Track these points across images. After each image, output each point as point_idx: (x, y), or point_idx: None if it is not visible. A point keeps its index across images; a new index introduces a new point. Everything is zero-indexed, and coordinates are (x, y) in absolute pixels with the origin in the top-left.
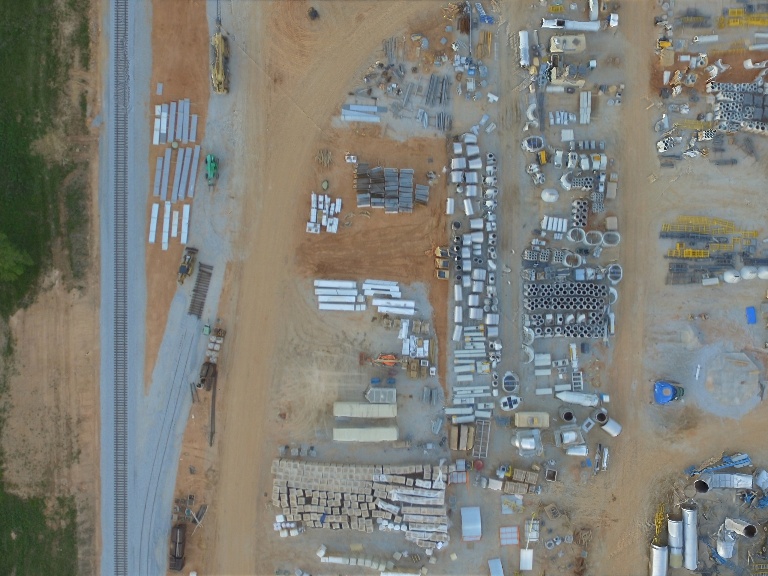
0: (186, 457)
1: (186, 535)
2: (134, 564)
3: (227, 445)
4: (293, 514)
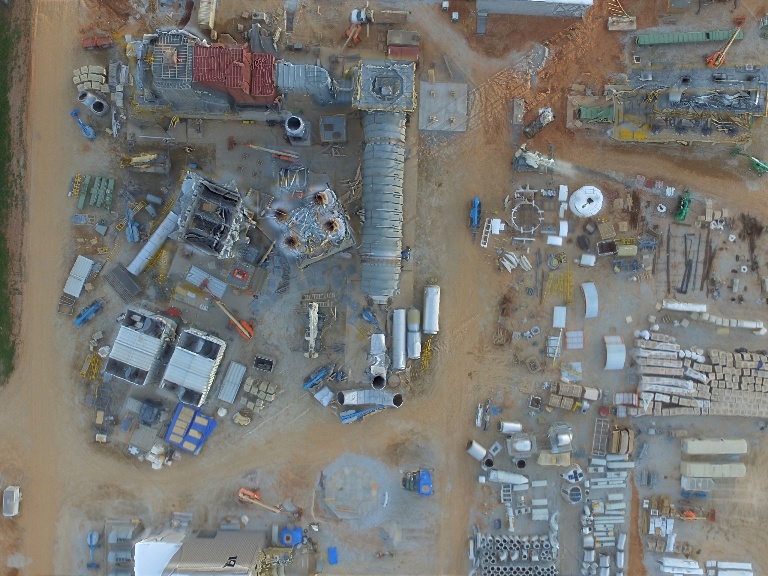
0: None
1: None
2: None
3: None
4: None
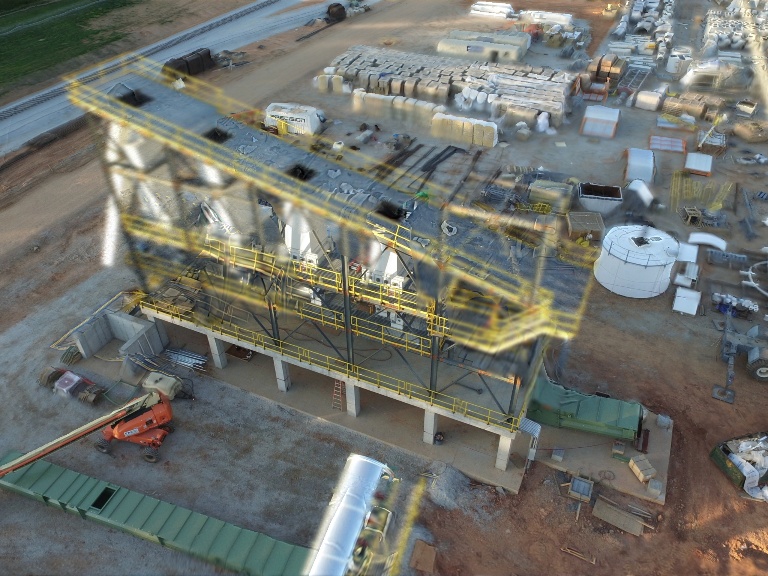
0: (264, 41)
1: (206, 70)
2: (126, 71)
3: (313, 44)
4: (349, 68)
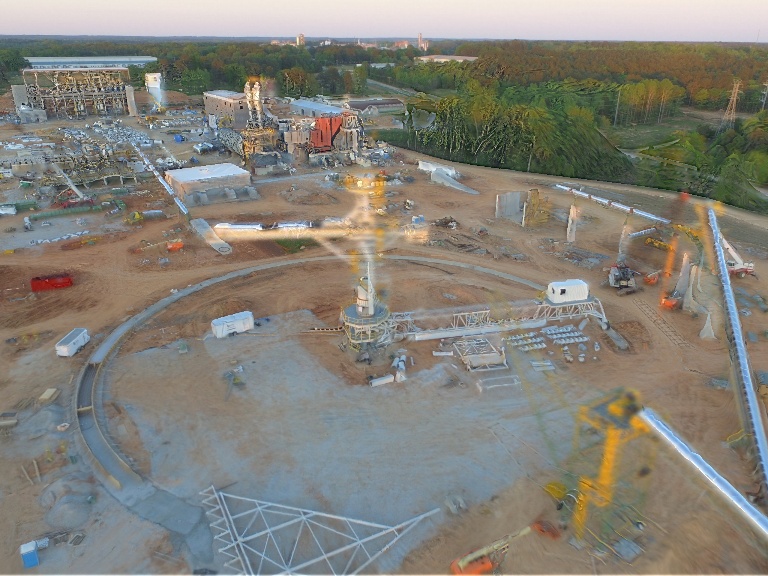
0: None
1: None
2: None
3: None
4: None
